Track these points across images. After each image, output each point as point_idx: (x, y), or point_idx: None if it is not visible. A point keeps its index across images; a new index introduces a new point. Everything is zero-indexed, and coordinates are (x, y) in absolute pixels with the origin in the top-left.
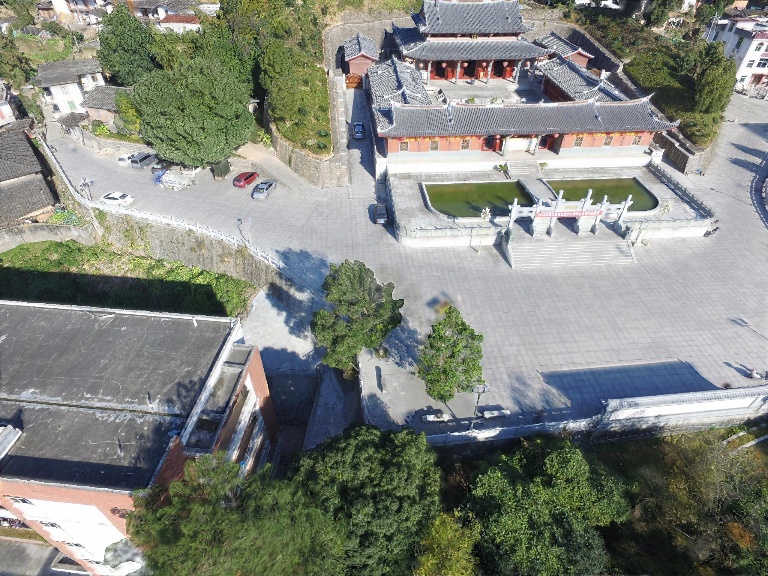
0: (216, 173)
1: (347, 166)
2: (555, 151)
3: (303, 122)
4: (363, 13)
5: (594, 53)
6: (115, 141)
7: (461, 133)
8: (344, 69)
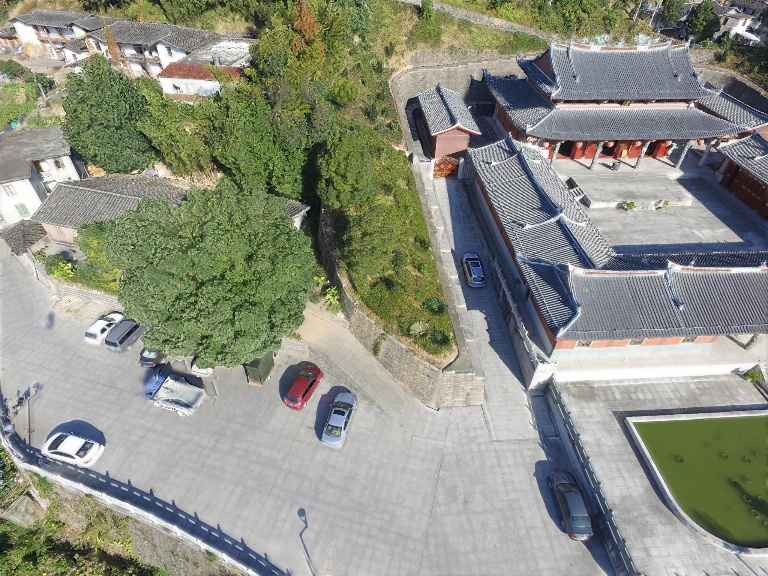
0: (251, 375)
1: None
2: None
3: (399, 281)
4: (441, 53)
5: None
6: (83, 289)
7: (702, 332)
8: (420, 137)
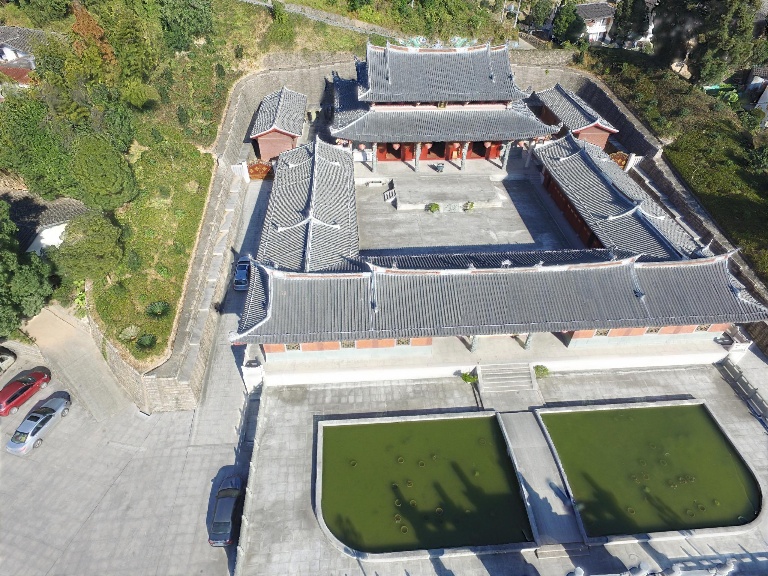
0: None
1: (205, 360)
2: (562, 337)
3: (128, 285)
4: (295, 55)
5: (617, 120)
6: None
7: (390, 335)
8: None
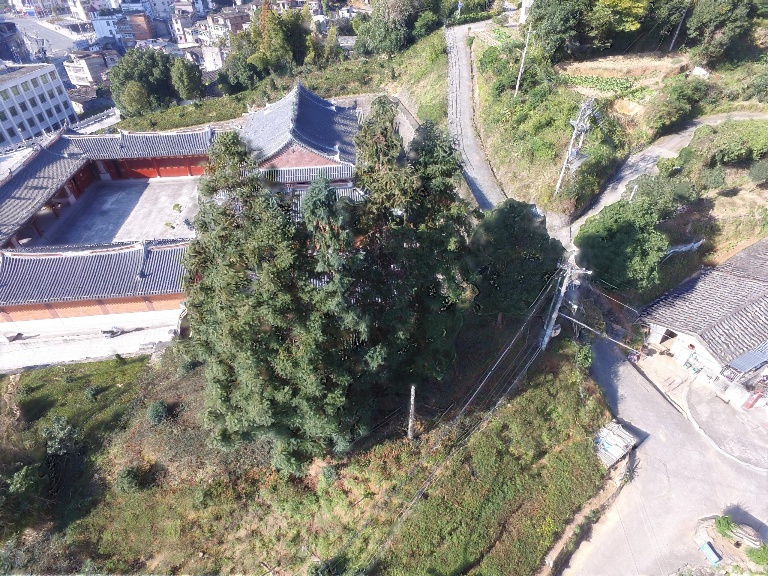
0: None
1: None
2: None
3: None
4: None
5: None
6: None
7: None
8: None
